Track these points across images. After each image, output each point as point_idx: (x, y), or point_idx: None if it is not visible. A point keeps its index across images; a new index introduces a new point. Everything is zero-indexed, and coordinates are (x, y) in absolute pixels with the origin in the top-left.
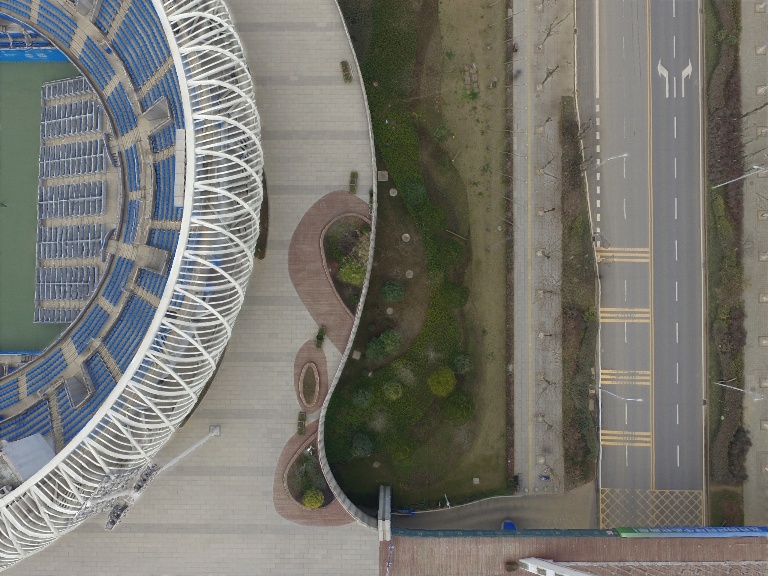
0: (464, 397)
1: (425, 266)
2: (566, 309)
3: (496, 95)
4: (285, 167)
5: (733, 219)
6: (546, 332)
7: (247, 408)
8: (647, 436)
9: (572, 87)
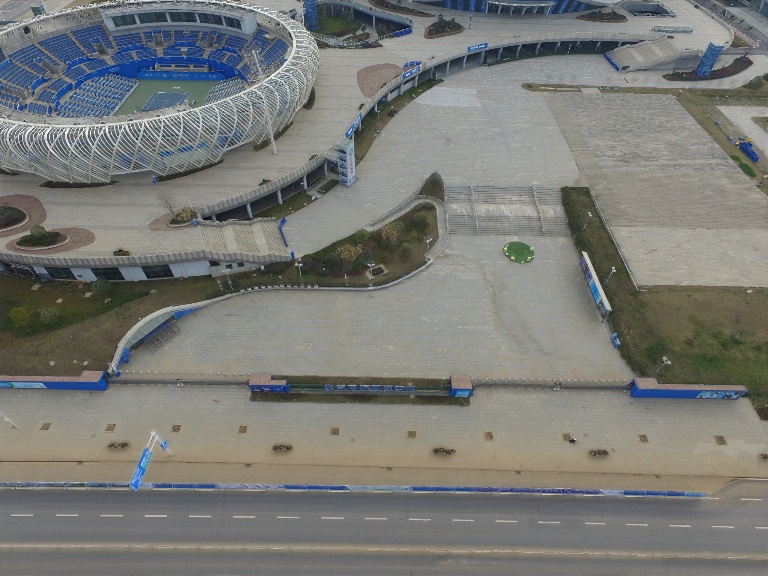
0: None
1: None
2: None
3: None
4: None
5: None
6: None
7: None
8: None
9: None
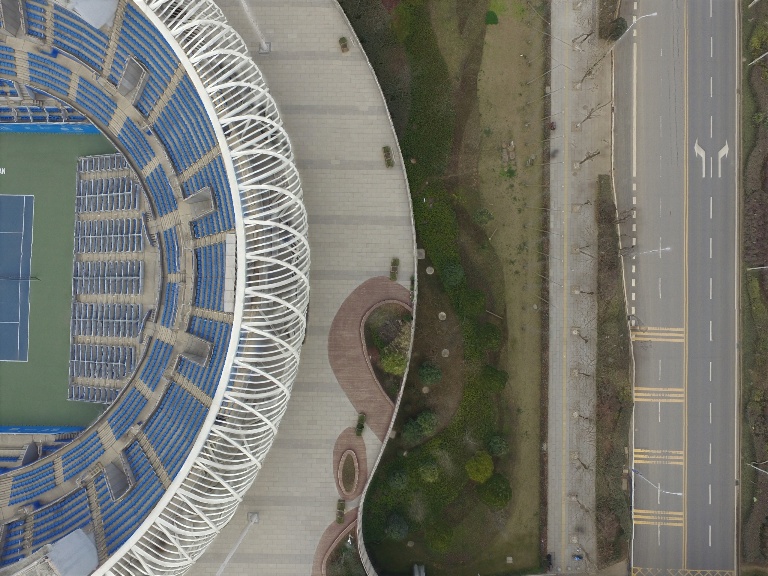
0: (503, 485)
1: (461, 345)
2: (601, 389)
3: (533, 173)
4: (326, 252)
5: (767, 301)
6: (580, 411)
7: (286, 495)
8: (679, 516)
9: (609, 165)
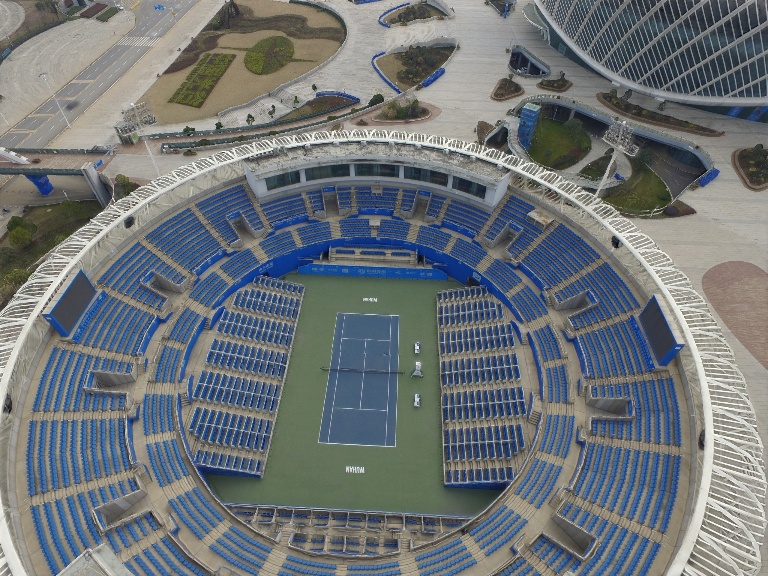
0: (7, 225)
1: None
2: None
3: None
4: None
5: None
6: None
7: None
8: None
9: None
